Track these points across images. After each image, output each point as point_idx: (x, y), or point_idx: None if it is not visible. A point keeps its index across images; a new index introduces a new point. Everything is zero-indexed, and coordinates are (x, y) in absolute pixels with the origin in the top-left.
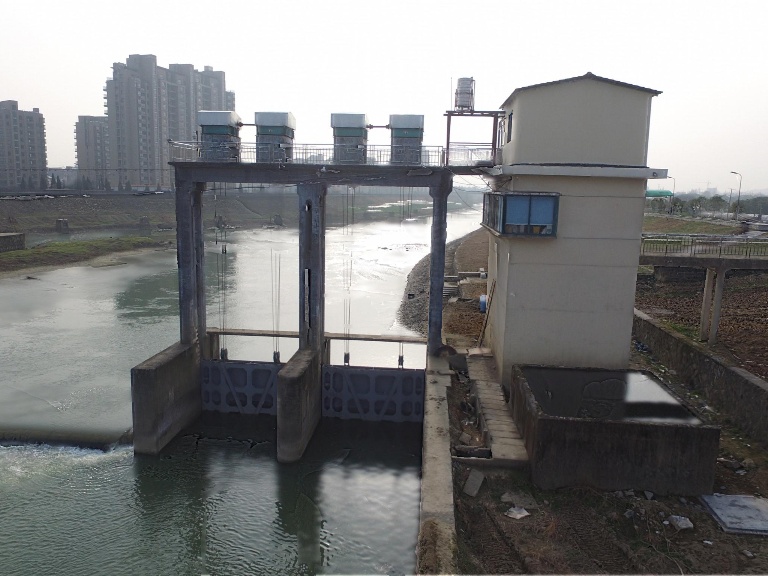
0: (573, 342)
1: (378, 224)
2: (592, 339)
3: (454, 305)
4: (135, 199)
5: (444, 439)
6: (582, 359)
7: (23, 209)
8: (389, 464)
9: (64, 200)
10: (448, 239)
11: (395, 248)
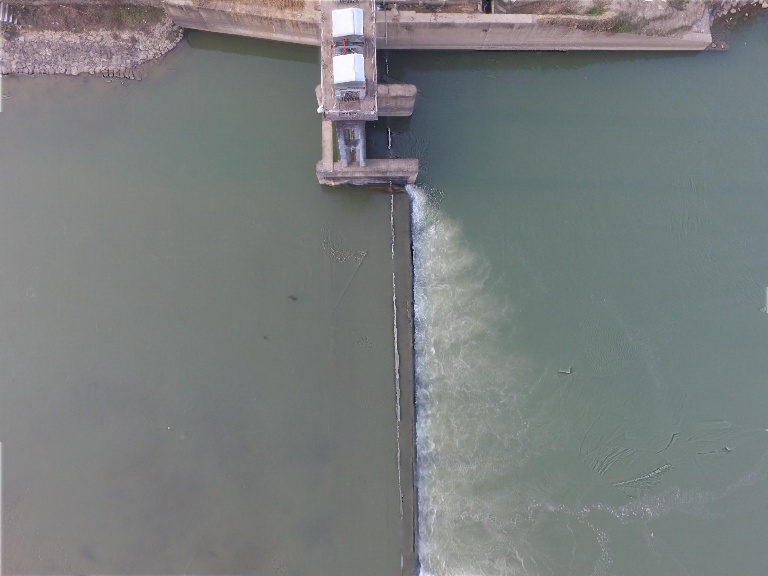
0: None
1: None
2: None
3: (206, 1)
4: None
5: (479, 16)
6: None
7: None
8: (408, 64)
9: None
10: None
11: None
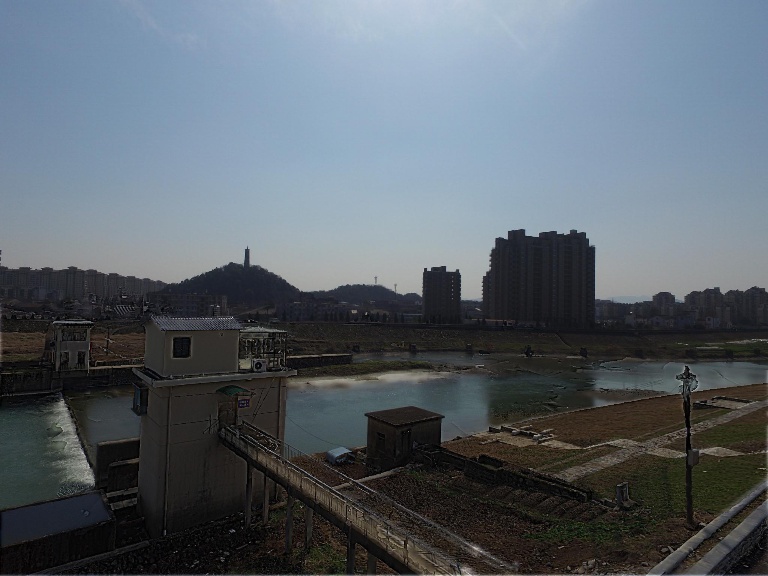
0: (147, 488)
1: (649, 364)
2: (150, 489)
3: None
4: (475, 331)
5: None
6: (148, 502)
7: (400, 336)
8: None
9: (428, 331)
10: (716, 387)
11: (616, 391)
